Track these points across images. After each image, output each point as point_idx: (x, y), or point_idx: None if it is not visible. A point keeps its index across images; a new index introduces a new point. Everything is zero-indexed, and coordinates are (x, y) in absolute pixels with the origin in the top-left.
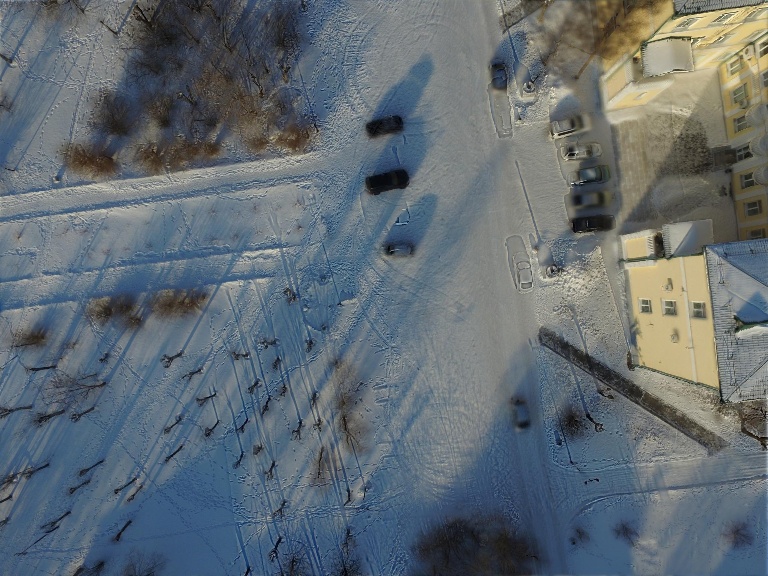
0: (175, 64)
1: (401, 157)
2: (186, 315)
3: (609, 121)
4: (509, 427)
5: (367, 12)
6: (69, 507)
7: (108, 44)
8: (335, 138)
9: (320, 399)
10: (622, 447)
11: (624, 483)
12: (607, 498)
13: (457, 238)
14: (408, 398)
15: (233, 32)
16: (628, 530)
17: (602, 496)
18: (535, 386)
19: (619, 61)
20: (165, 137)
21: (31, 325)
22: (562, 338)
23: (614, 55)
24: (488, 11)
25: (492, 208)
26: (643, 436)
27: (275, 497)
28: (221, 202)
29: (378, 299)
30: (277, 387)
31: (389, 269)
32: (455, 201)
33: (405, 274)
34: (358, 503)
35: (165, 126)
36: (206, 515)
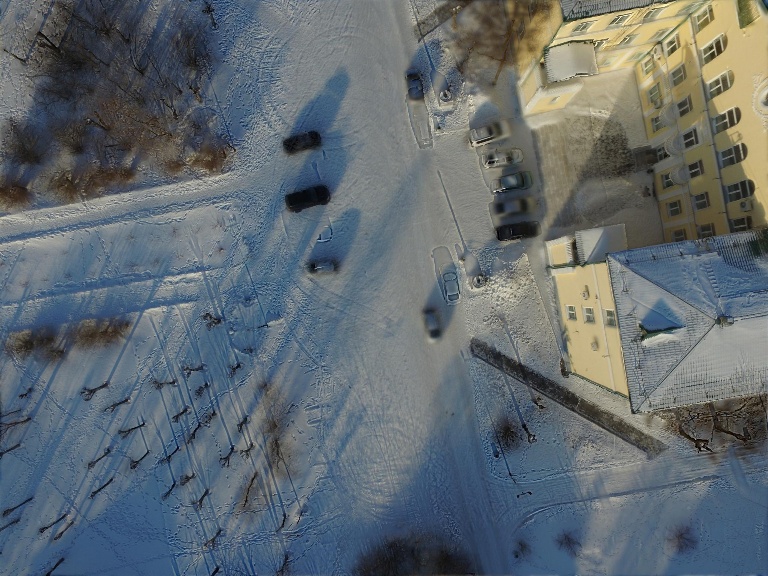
0: (84, 89)
1: (321, 173)
2: (110, 345)
3: (529, 126)
4: (445, 441)
5: (279, 27)
6: None
7: (17, 72)
8: (253, 156)
9: (251, 423)
10: (560, 456)
11: (565, 492)
12: (548, 508)
13: (382, 252)
14: (341, 417)
15: (144, 54)
16: (570, 540)
17: (543, 507)
18: (469, 398)
19: (529, 66)
20: (79, 164)
21: None
22: (494, 348)
23: (526, 60)
24: (402, 20)
25: (416, 220)
26: (581, 444)
27: (210, 526)
28: (140, 227)
29: (305, 318)
30: (207, 413)
31: (315, 287)
32: (378, 215)
33: (331, 291)
34: (295, 527)
35: (78, 153)
36: (140, 548)
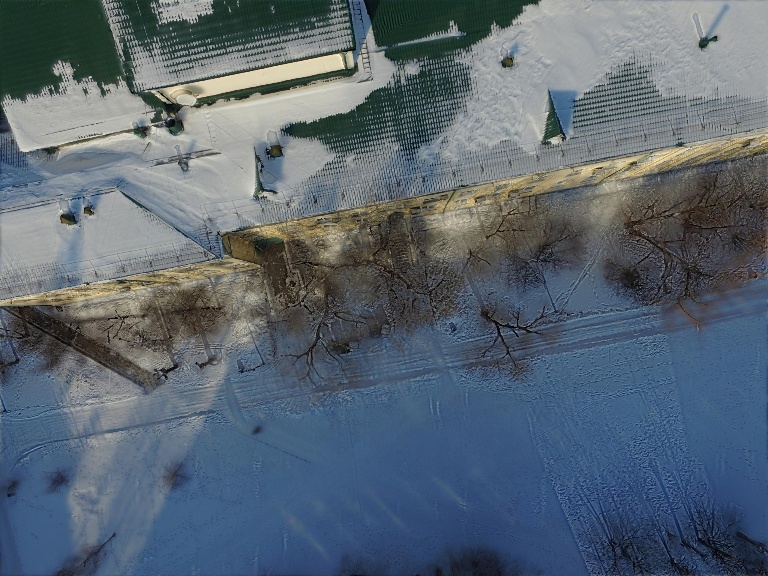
0: None
1: None
2: None
3: None
4: None
5: None
6: None
7: None
8: None
9: None
10: (55, 391)
11: (62, 429)
12: (44, 446)
13: None
14: None
15: None
16: (62, 478)
17: (39, 444)
18: None
19: None
20: None
21: None
22: None
23: None
24: None
25: None
26: (74, 378)
27: None
28: None
29: None
30: None
31: None
32: None
33: None
34: None
35: None
36: None
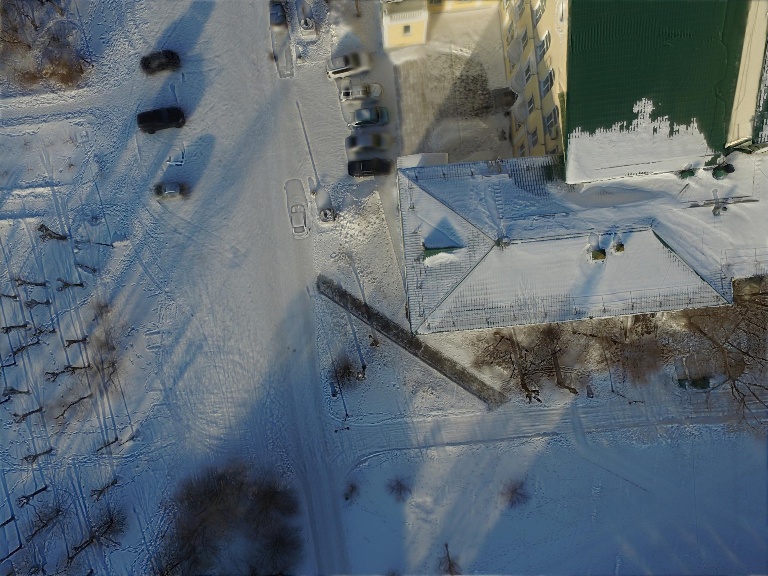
0: None
1: (179, 95)
2: None
3: (392, 62)
4: (285, 377)
5: None
6: None
7: None
8: (112, 74)
9: (90, 344)
10: (399, 400)
11: (401, 438)
12: (383, 453)
13: (234, 180)
14: (181, 345)
15: None
16: (402, 486)
17: (378, 451)
18: (312, 336)
19: None
20: None
21: None
22: (340, 286)
23: None
24: None
25: (271, 150)
26: (420, 389)
27: (41, 444)
28: None
29: (152, 242)
30: (46, 331)
31: (164, 211)
32: (233, 142)
33: (180, 217)
34: (126, 452)
35: None
36: None
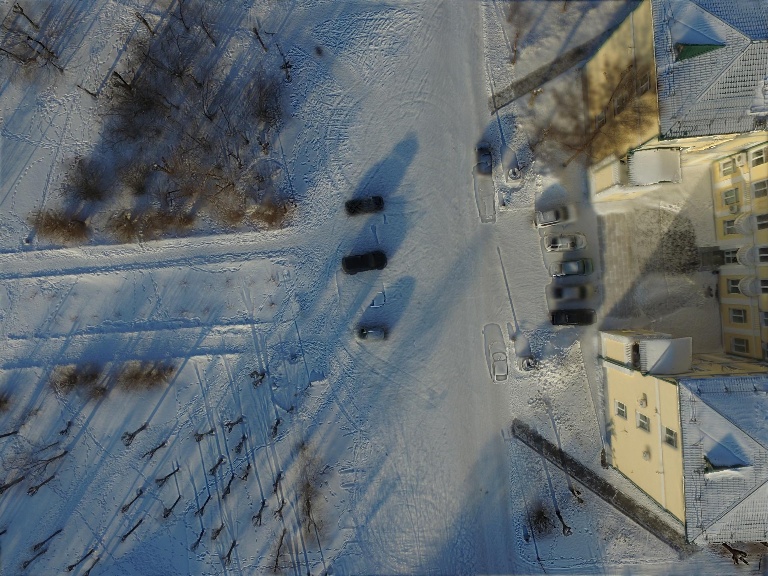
0: (152, 132)
1: (380, 237)
2: (152, 387)
3: (596, 212)
4: (477, 519)
5: (353, 86)
6: (25, 575)
7: (86, 105)
8: (313, 214)
9: (285, 480)
10: (591, 546)
11: None
12: None
13: (433, 323)
14: (375, 484)
15: (214, 100)
16: None
17: None
18: (505, 479)
19: (607, 159)
20: (140, 204)
21: None
22: (536, 431)
23: (603, 150)
24: (477, 91)
25: (471, 294)
26: (613, 537)
27: None
28: (193, 274)
29: (349, 381)
30: (241, 465)
31: (362, 351)
32: (433, 285)
33: (378, 357)
34: None
35: (140, 194)
36: None
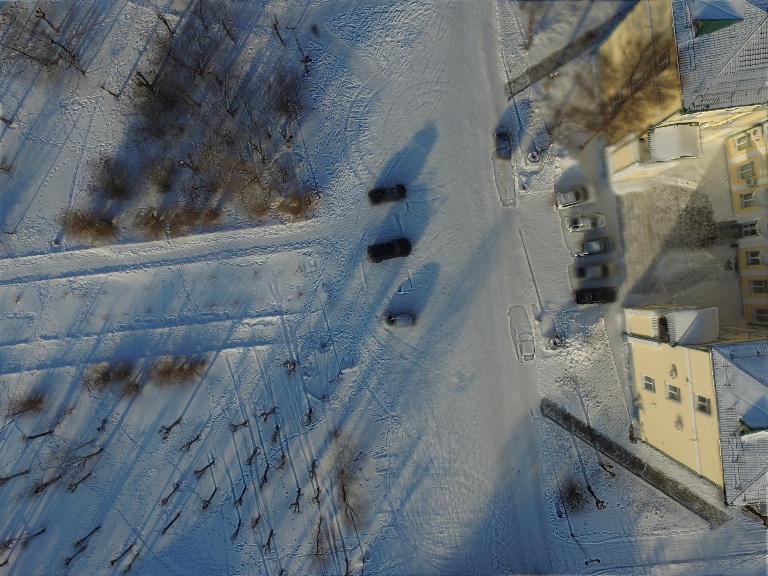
0: (176, 130)
1: (404, 224)
2: (185, 382)
3: (614, 192)
4: (509, 498)
5: (371, 77)
6: (65, 573)
7: (109, 107)
8: (337, 204)
9: (319, 468)
10: (623, 520)
11: (625, 556)
12: (607, 571)
13: (459, 307)
14: (408, 468)
15: (235, 96)
16: None
17: (602, 569)
18: (536, 457)
19: (625, 138)
20: (165, 201)
21: (28, 390)
22: (564, 409)
23: (620, 130)
24: (493, 78)
25: (495, 277)
26: (644, 510)
27: (273, 566)
28: (221, 268)
29: (379, 368)
30: (276, 455)
31: (390, 337)
32: (458, 270)
33: (406, 343)
34: (356, 573)
35: (166, 191)
36: None
